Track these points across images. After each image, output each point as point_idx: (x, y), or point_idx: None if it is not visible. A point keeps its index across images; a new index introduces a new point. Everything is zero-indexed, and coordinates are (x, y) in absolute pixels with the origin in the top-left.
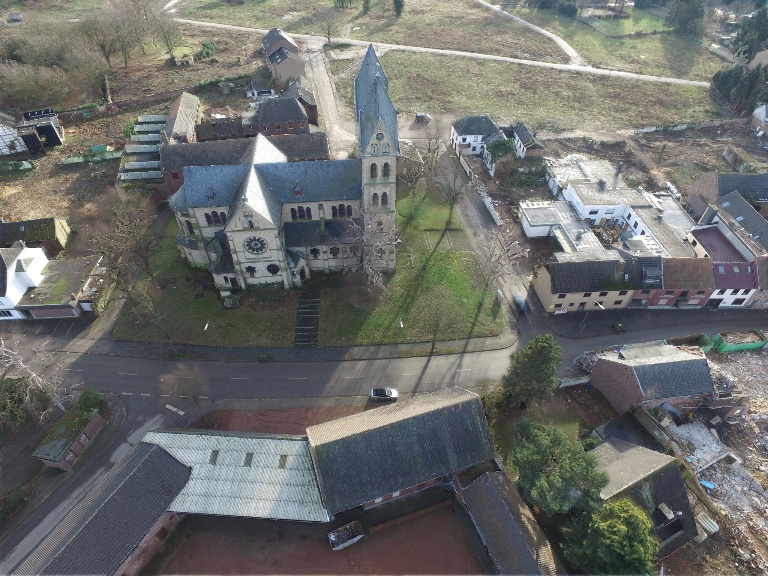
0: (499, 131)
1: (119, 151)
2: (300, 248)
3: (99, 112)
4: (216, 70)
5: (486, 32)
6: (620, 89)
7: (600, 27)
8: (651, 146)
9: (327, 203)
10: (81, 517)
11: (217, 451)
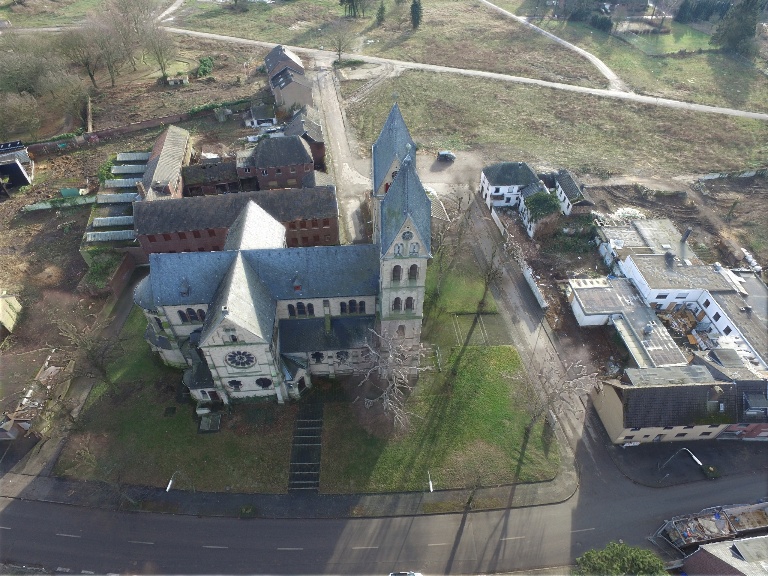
0: (539, 181)
1: (93, 196)
2: (299, 353)
3: (76, 143)
4: (213, 91)
5: (513, 48)
6: (670, 122)
7: (638, 44)
8: (716, 198)
9: (334, 299)
10: None
11: None
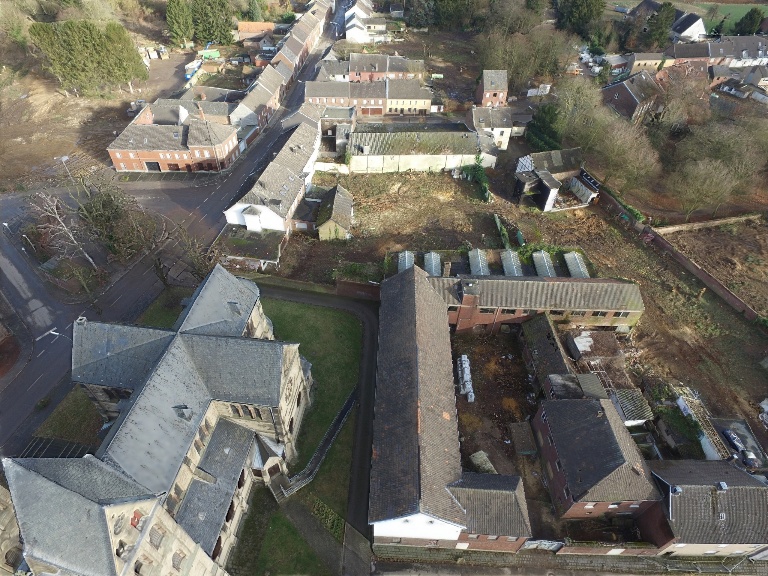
0: None
1: None
2: None
3: (634, 226)
4: None
5: None
6: None
7: None
8: None
9: None
10: None
11: None
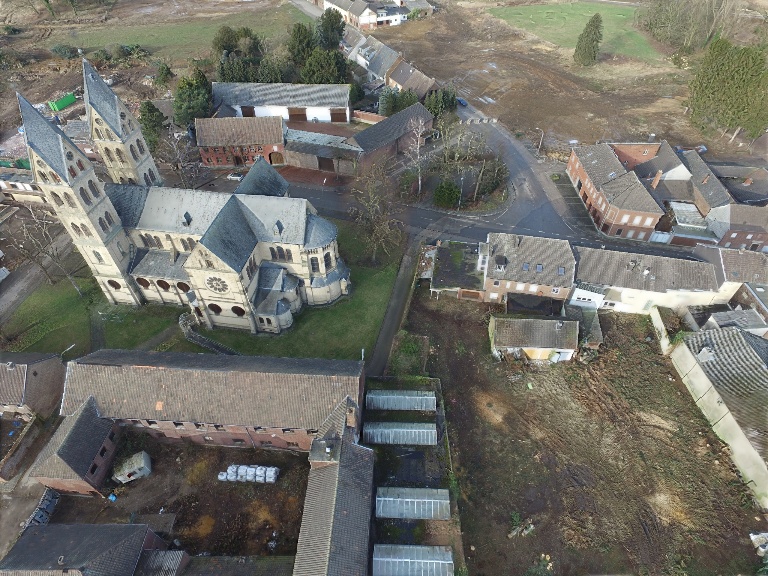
0: None
1: None
2: None
3: None
4: None
5: None
6: None
7: None
8: None
9: None
10: (384, 129)
11: (328, 143)
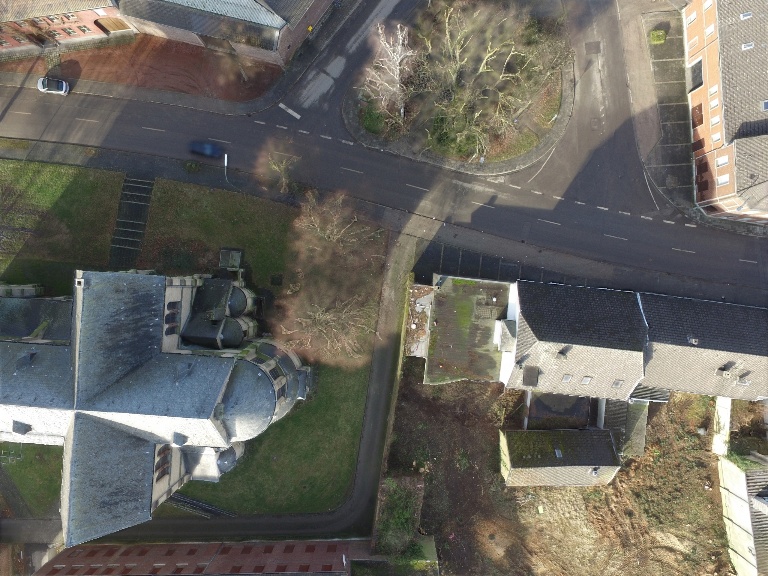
0: None
1: None
2: None
3: None
4: None
5: None
6: None
7: None
8: None
9: None
10: None
11: None
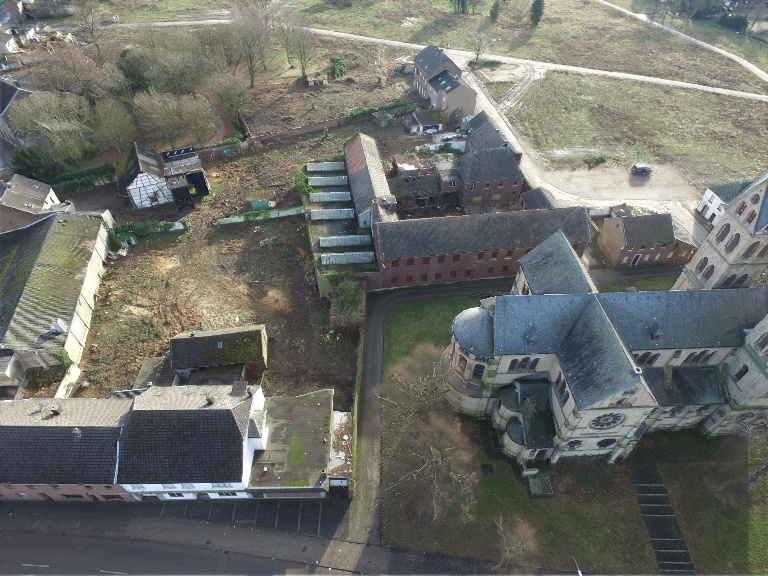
0: None
1: (287, 209)
2: None
3: (240, 149)
4: (357, 93)
5: (650, 49)
6: None
7: None
8: None
9: (688, 349)
10: None
11: None
